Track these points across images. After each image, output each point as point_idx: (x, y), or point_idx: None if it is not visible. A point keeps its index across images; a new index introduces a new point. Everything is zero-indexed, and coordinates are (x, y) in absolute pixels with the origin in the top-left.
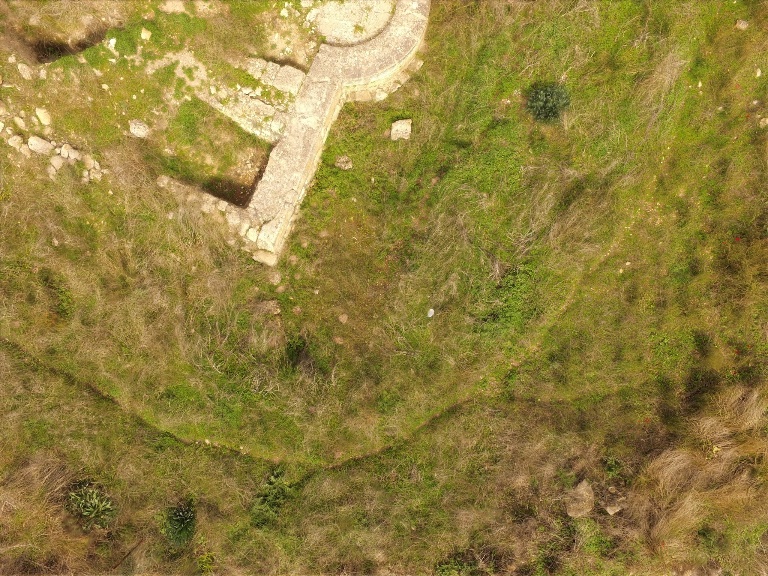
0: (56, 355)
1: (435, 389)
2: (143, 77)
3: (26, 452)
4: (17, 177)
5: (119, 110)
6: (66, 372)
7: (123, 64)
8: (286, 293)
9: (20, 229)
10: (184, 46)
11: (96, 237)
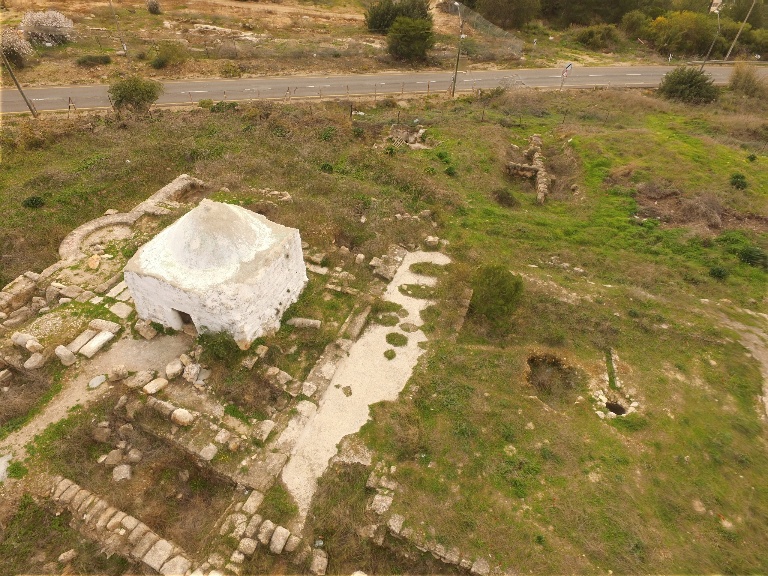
0: None
1: None
2: None
3: None
4: None
5: None
6: None
7: None
8: None
9: None
10: None
11: None
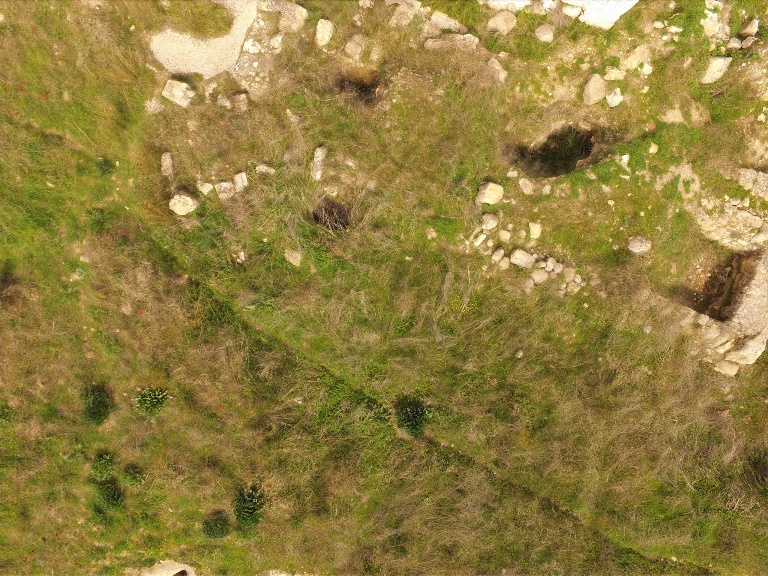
0: (521, 471)
1: None
2: (652, 193)
3: (482, 568)
4: (482, 287)
5: (618, 225)
6: (525, 486)
7: (636, 181)
8: (738, 402)
9: (482, 340)
10: (683, 158)
11: (563, 349)
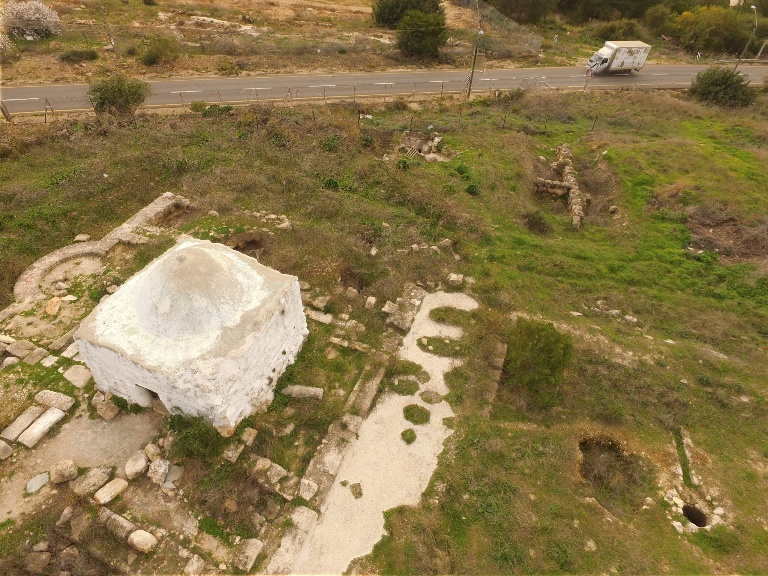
0: None
1: (118, 159)
2: None
3: None
4: None
5: None
6: None
7: None
8: None
9: None
10: None
11: None
